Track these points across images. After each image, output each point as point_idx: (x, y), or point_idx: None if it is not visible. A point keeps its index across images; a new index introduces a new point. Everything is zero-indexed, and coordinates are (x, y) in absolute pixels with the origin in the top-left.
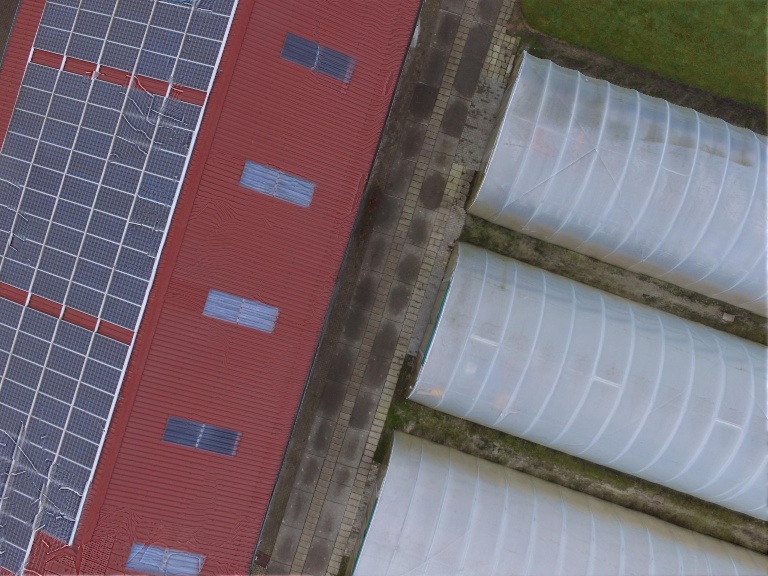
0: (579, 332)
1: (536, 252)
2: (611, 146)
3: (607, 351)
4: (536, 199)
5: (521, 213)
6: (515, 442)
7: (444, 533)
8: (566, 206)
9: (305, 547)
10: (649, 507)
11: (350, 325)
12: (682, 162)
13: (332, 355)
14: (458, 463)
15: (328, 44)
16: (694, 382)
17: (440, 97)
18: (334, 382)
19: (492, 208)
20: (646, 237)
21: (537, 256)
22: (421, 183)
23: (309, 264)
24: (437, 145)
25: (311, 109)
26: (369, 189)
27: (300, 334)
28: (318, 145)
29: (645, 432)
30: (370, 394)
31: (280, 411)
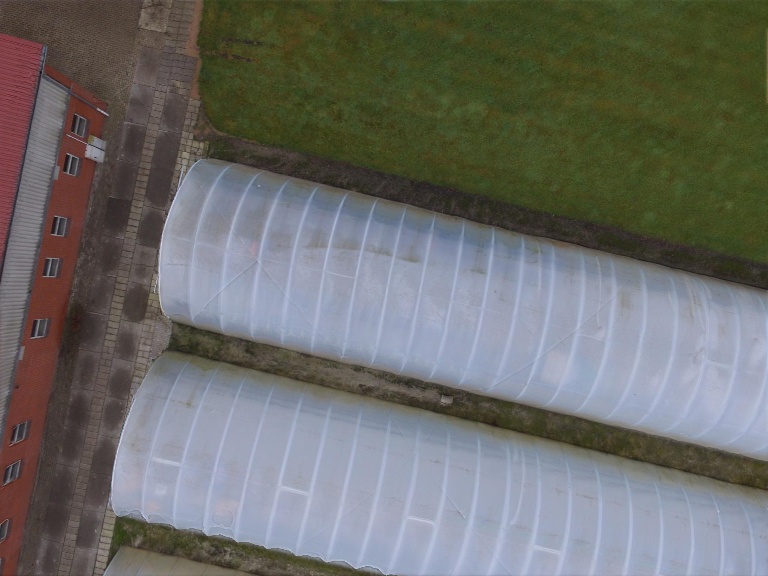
0: (266, 442)
1: (247, 353)
2: (273, 256)
3: (293, 460)
4: (215, 312)
5: (212, 323)
6: (245, 545)
7: None
8: None
9: None
10: None
11: (67, 445)
12: (346, 265)
13: (52, 477)
14: (180, 575)
15: None
16: (383, 482)
17: (133, 209)
18: (57, 504)
19: None
20: (333, 337)
21: (249, 357)
22: (123, 297)
23: None
24: (135, 257)
25: None
26: (71, 308)
27: None
28: None
29: (341, 536)
30: (94, 512)
31: None
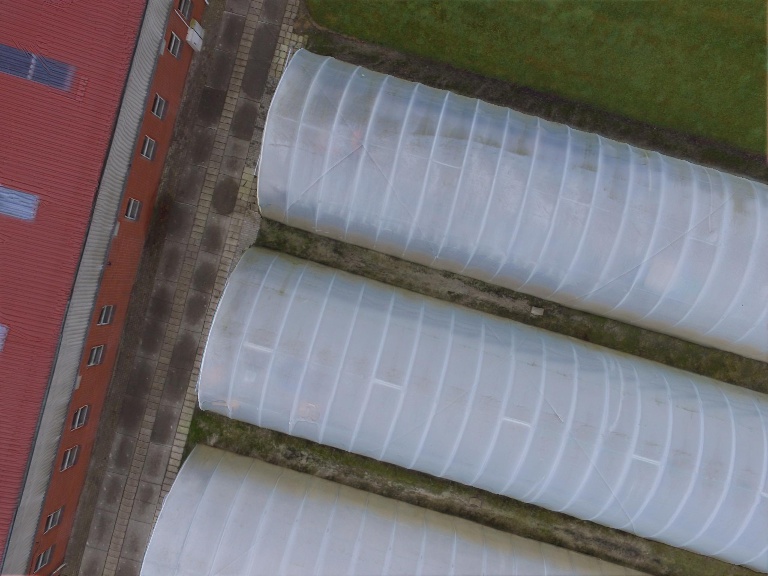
0: (360, 334)
1: (335, 253)
2: (379, 141)
3: (388, 352)
4: (313, 199)
5: (306, 214)
6: (323, 450)
7: (227, 549)
8: (345, 205)
9: (111, 569)
10: (466, 511)
11: (147, 337)
12: (453, 154)
13: (130, 369)
14: (258, 475)
15: (58, 51)
16: (480, 380)
17: (228, 100)
18: (133, 397)
19: (283, 211)
20: (431, 233)
21: (337, 257)
22: (213, 188)
23: (54, 278)
24: (227, 149)
25: (44, 118)
26: (159, 197)
27: (32, 351)
28: (54, 155)
29: (433, 434)
30: (171, 407)
31: (15, 432)
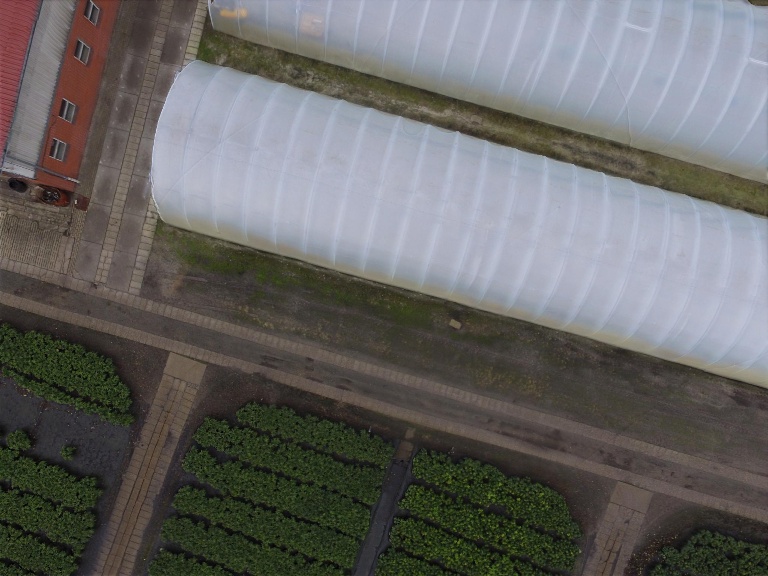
0: None
1: None
2: None
3: None
4: None
5: None
6: (328, 69)
7: (238, 117)
8: None
9: (124, 187)
10: (468, 128)
11: None
12: None
13: None
14: None
15: None
16: None
17: None
18: (143, 19)
19: None
20: None
21: None
22: None
23: None
24: None
25: None
26: None
27: None
28: None
29: (434, 8)
30: (180, 29)
31: None
